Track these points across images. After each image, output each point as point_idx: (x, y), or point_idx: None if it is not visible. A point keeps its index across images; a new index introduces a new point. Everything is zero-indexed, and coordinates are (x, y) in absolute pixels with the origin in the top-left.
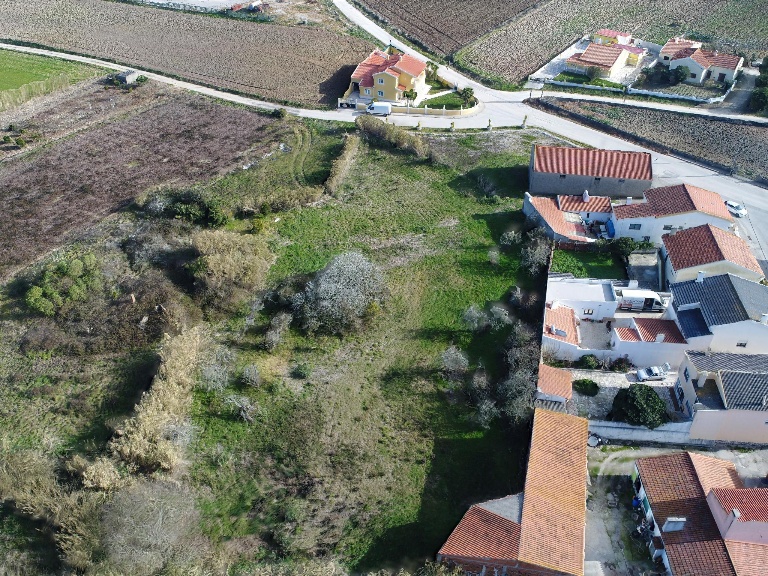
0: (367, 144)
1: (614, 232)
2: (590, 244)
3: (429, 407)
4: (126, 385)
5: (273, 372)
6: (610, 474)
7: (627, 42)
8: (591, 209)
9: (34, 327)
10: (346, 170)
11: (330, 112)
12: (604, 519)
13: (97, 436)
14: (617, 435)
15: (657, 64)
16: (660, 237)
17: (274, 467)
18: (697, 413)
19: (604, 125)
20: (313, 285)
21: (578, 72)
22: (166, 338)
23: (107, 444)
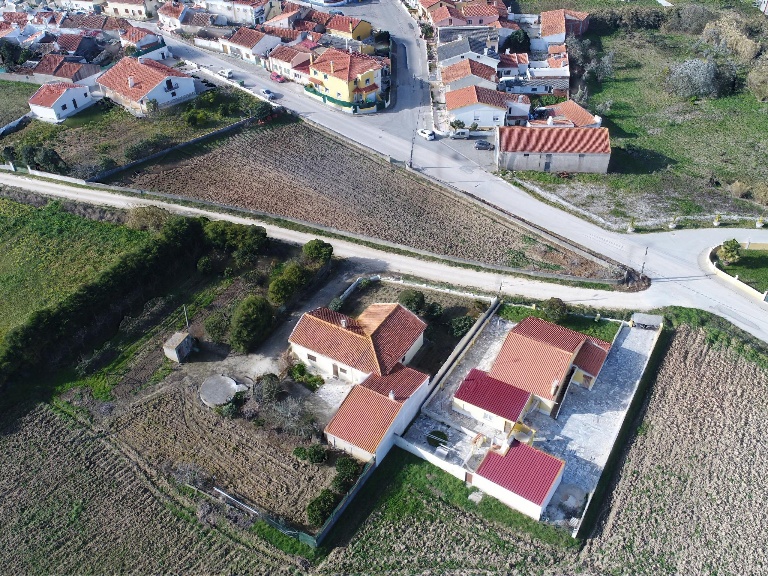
0: None
1: None
2: None
3: (613, 59)
4: None
5: None
6: None
7: None
8: None
9: None
10: None
11: None
12: None
13: None
14: None
15: None
16: None
17: None
18: None
19: None
20: None
21: None
22: None
23: None
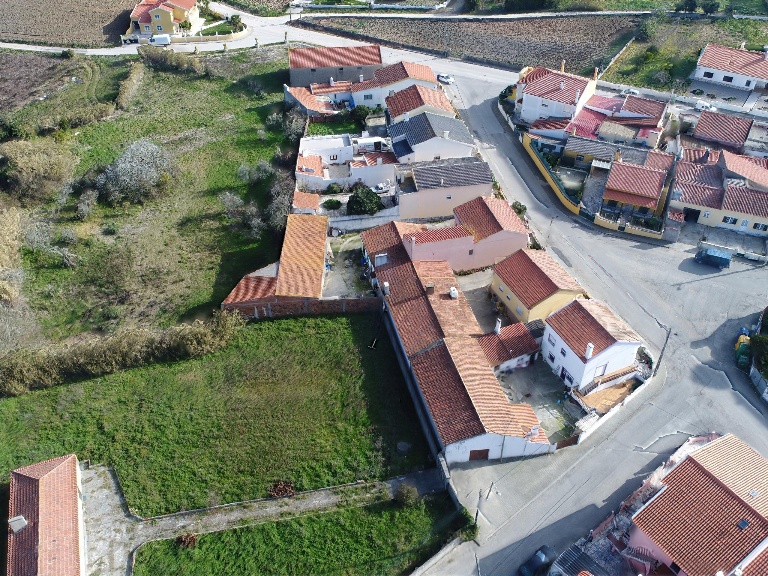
0: (151, 69)
1: (354, 104)
2: (336, 115)
3: (216, 236)
4: None
5: (88, 233)
6: (347, 250)
7: None
8: (337, 91)
9: None
10: (134, 90)
11: (115, 48)
12: (342, 274)
13: None
14: (352, 226)
15: None
16: None
17: (97, 291)
18: (400, 198)
19: (351, 33)
20: (112, 168)
21: None
22: None
23: None
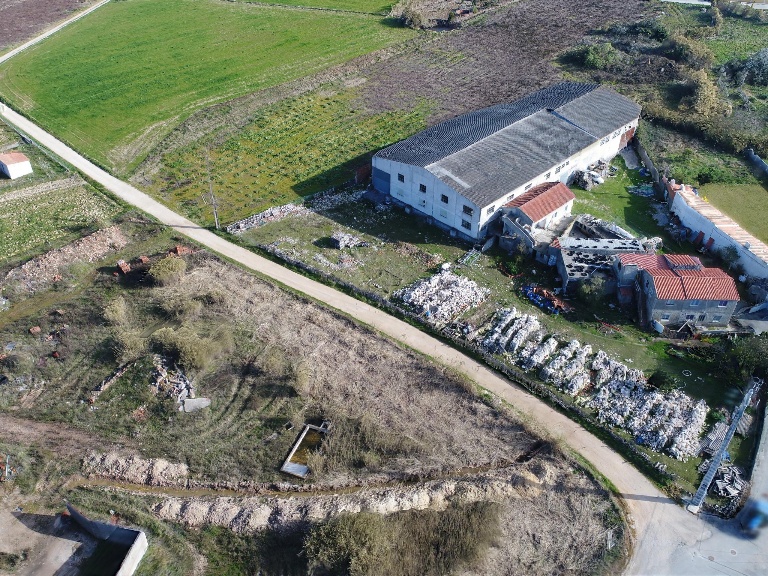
0: (722, 14)
1: None
2: None
3: None
4: (670, 94)
5: (746, 95)
6: None
7: None
8: None
9: (594, 73)
10: None
11: None
12: None
13: (672, 108)
14: None
15: None
16: None
17: None
18: None
19: None
20: None
21: None
22: (691, 71)
23: (696, 101)
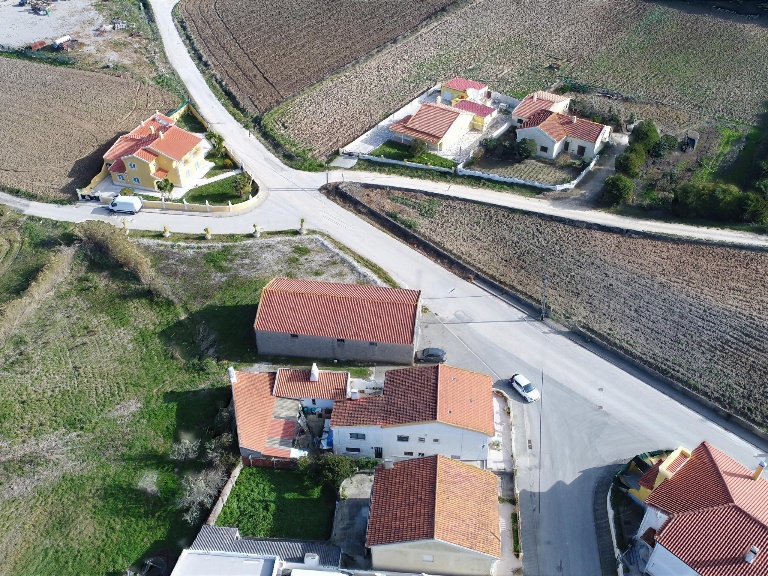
0: (84, 263)
1: (331, 441)
2: (292, 462)
3: None
4: None
5: None
6: None
7: (482, 95)
8: (316, 394)
9: None
10: (29, 311)
11: (66, 207)
12: None
13: None
14: None
15: (509, 128)
16: (396, 449)
17: None
18: None
19: (404, 230)
20: None
21: (405, 142)
22: None
23: None
